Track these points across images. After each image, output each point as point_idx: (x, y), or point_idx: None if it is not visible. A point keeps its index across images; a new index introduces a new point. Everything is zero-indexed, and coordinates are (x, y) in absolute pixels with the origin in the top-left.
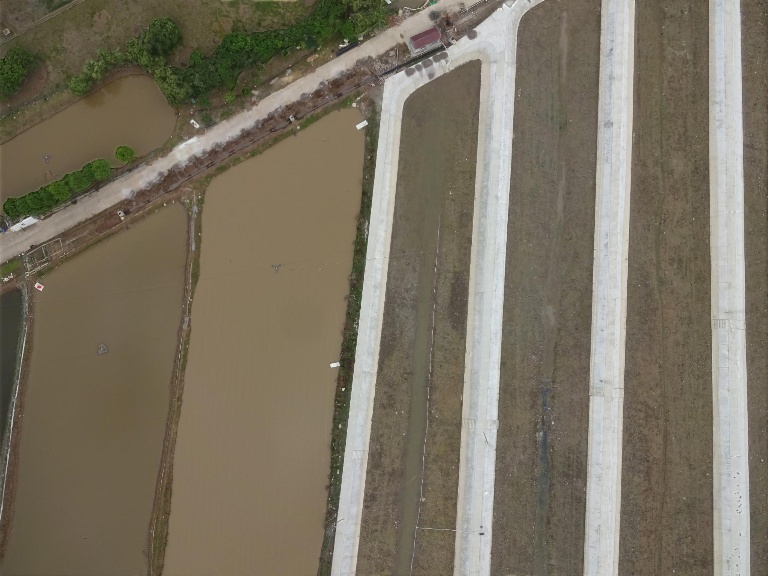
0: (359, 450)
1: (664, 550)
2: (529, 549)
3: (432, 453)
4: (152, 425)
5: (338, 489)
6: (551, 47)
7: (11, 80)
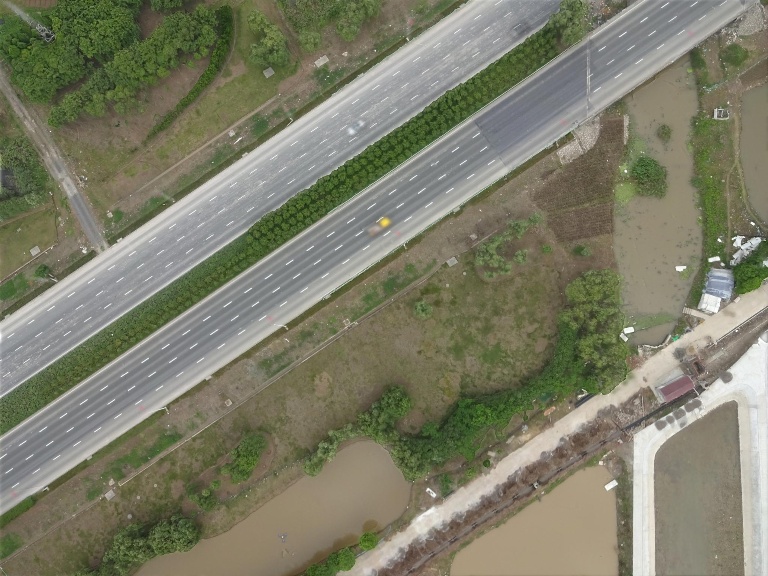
0: None
1: None
2: None
3: None
4: None
5: None
6: None
7: (247, 471)
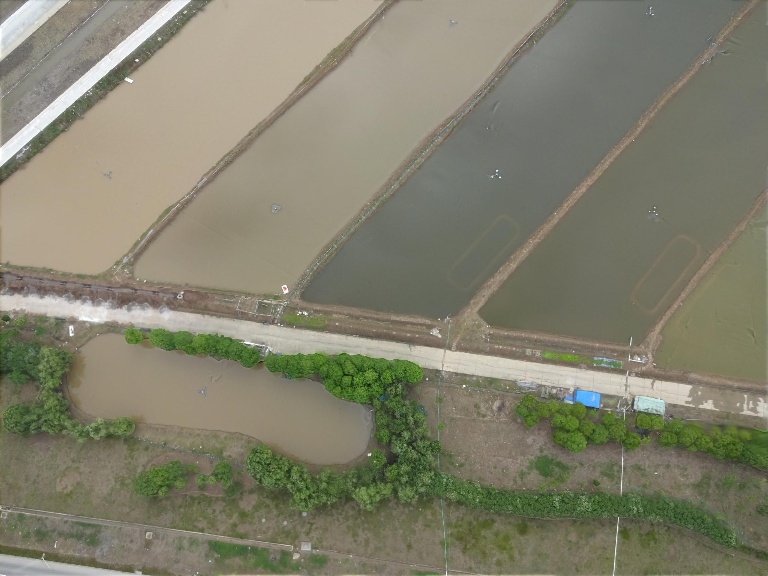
0: (160, 16)
1: None
2: None
3: None
4: (283, 131)
5: (194, 2)
6: None
7: (166, 469)
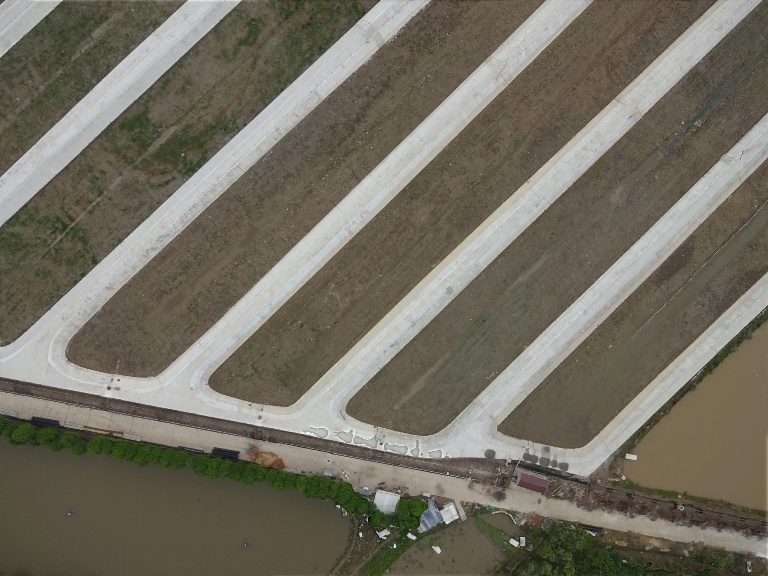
0: None
1: None
2: None
3: None
4: None
5: None
6: (432, 390)
7: None
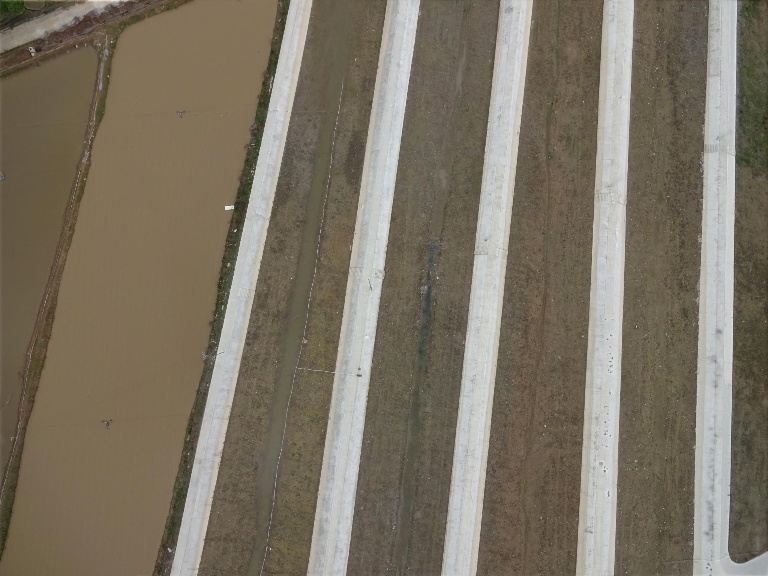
0: (245, 288)
1: (537, 405)
2: (406, 396)
3: (318, 298)
4: (41, 252)
5: (221, 324)
6: None
7: None
